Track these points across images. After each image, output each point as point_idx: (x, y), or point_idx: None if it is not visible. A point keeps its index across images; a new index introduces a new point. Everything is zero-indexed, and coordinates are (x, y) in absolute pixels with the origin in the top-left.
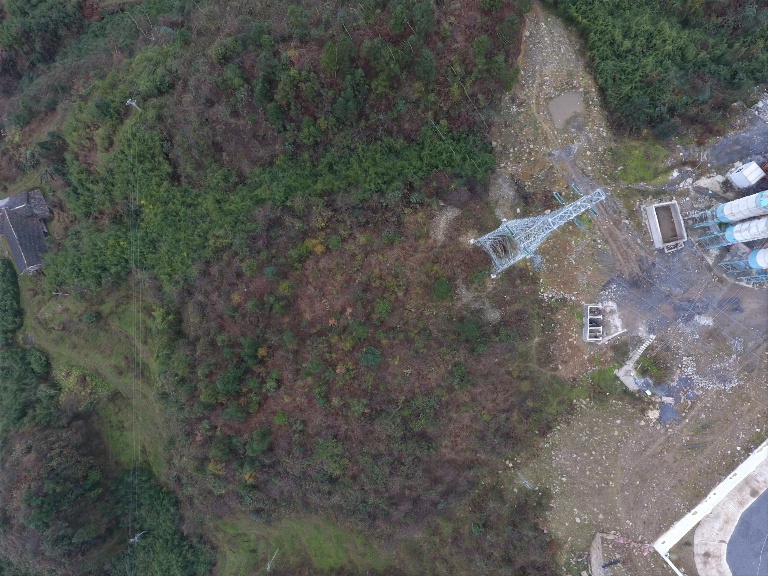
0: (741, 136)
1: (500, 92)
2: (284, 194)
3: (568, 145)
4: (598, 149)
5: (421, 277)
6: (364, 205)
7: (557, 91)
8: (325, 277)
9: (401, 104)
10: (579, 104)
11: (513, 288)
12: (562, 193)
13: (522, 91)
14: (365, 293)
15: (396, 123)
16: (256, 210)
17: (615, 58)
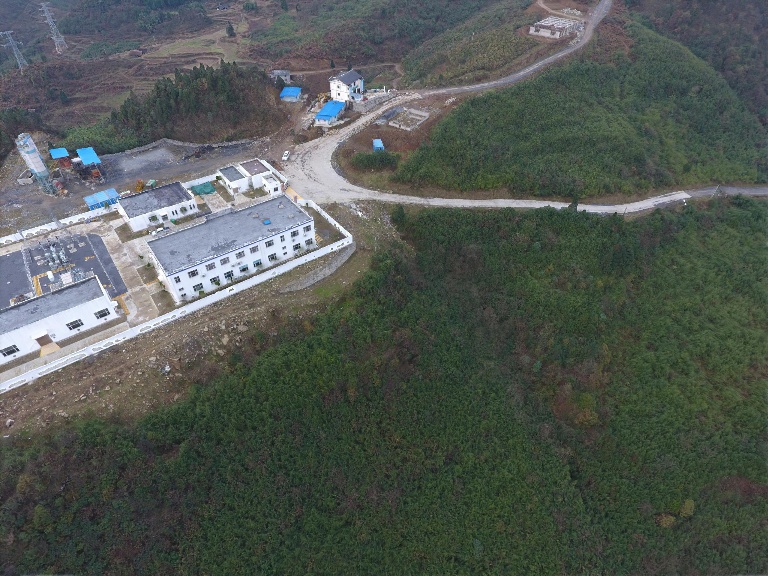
0: None
1: (6, 149)
2: None
3: None
4: None
5: None
6: None
7: None
8: None
9: None
10: (44, 156)
11: None
12: None
13: None
14: None
15: None
16: None
17: None
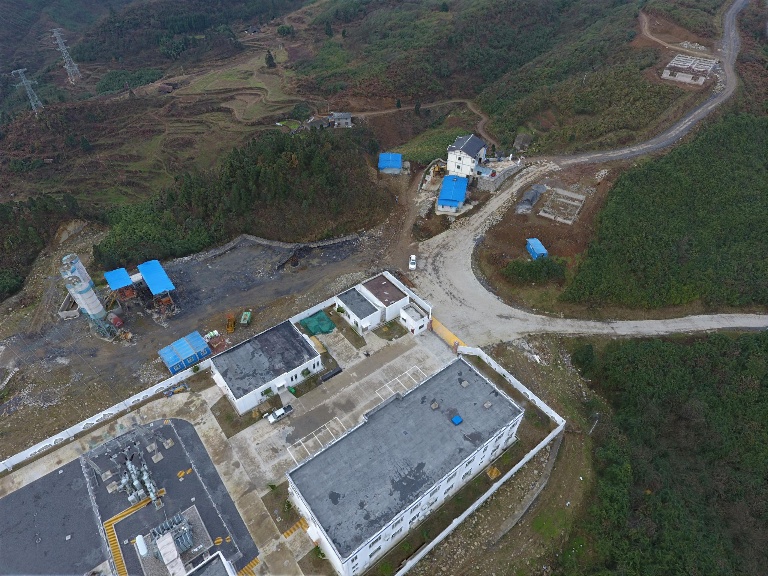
0: None
1: (35, 249)
2: None
3: None
4: None
5: None
6: None
7: None
8: None
9: None
10: (85, 259)
11: None
12: None
13: (54, 252)
14: None
15: None
16: None
17: None
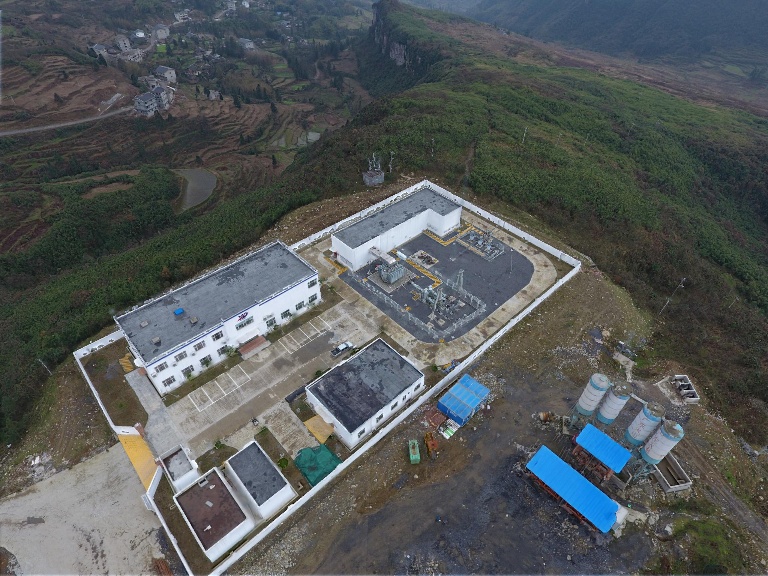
0: (625, 570)
1: None
2: None
3: None
4: None
5: None
6: None
7: None
8: None
9: None
10: None
11: None
12: (762, 515)
13: None
14: None
15: None
16: None
17: None
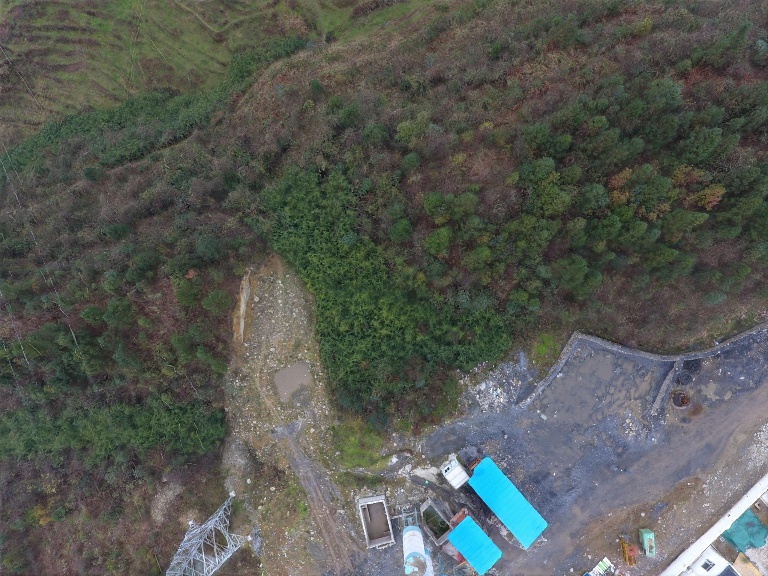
0: (457, 425)
1: None
2: (25, 448)
3: (292, 421)
4: (321, 427)
5: (137, 562)
6: (94, 472)
7: (282, 364)
8: (60, 540)
9: (116, 382)
10: (306, 376)
11: (233, 572)
12: (285, 471)
13: (246, 364)
14: (87, 571)
15: (125, 389)
16: (5, 456)
17: (335, 336)
